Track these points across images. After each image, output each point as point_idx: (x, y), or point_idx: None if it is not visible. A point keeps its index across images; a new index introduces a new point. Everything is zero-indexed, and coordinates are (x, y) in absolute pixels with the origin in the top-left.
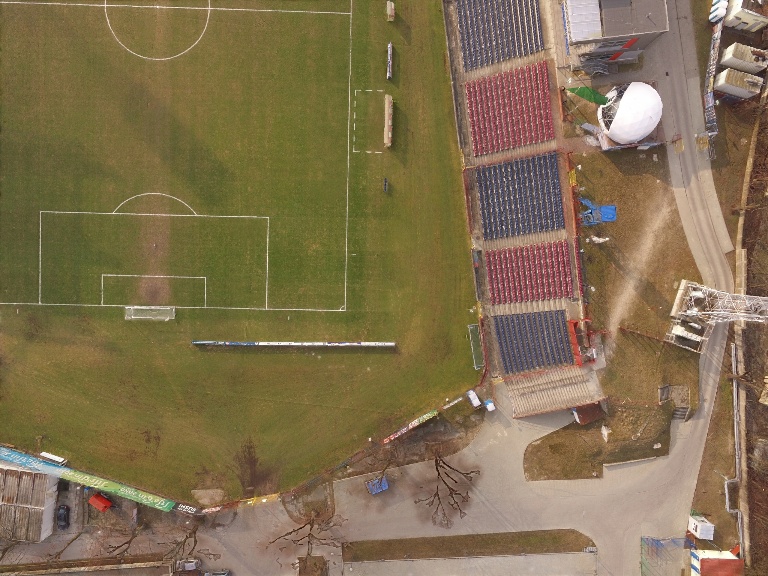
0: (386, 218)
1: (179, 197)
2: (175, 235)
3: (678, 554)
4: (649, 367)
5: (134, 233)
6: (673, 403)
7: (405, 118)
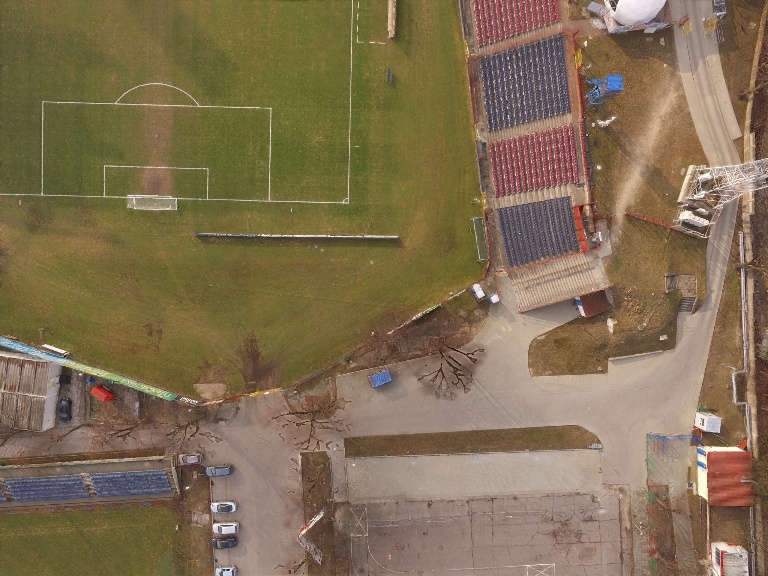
0: (390, 110)
1: (181, 87)
2: (177, 126)
3: (684, 451)
4: (655, 254)
5: (136, 124)
6: (680, 293)
7: (409, 8)
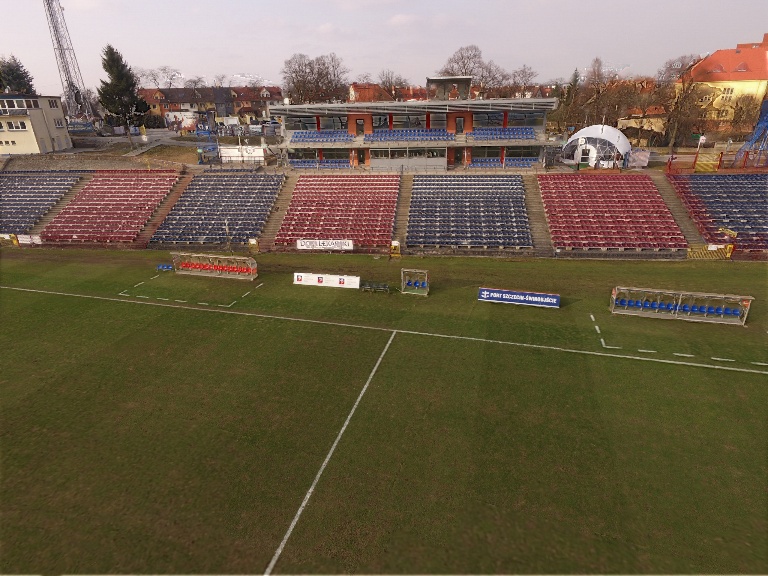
0: None
1: None
2: None
3: None
4: None
5: None
6: None
7: None
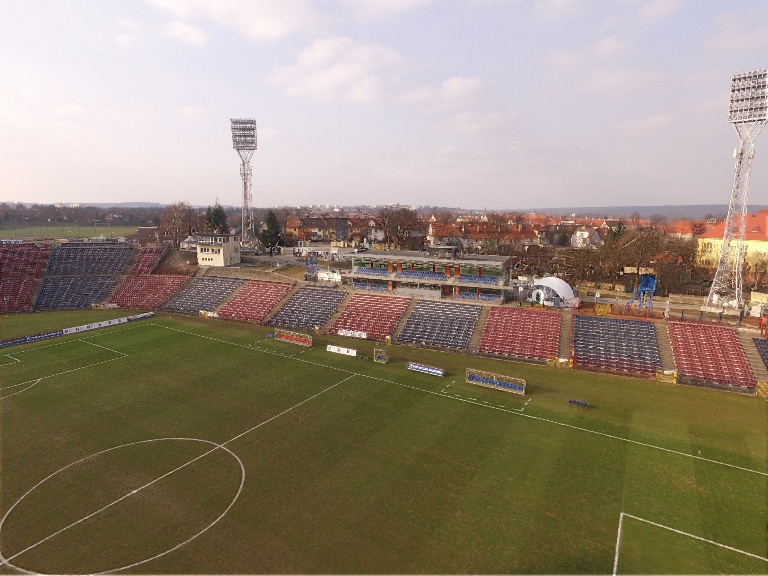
0: (630, 417)
1: None
2: None
3: None
4: None
5: None
6: None
7: None
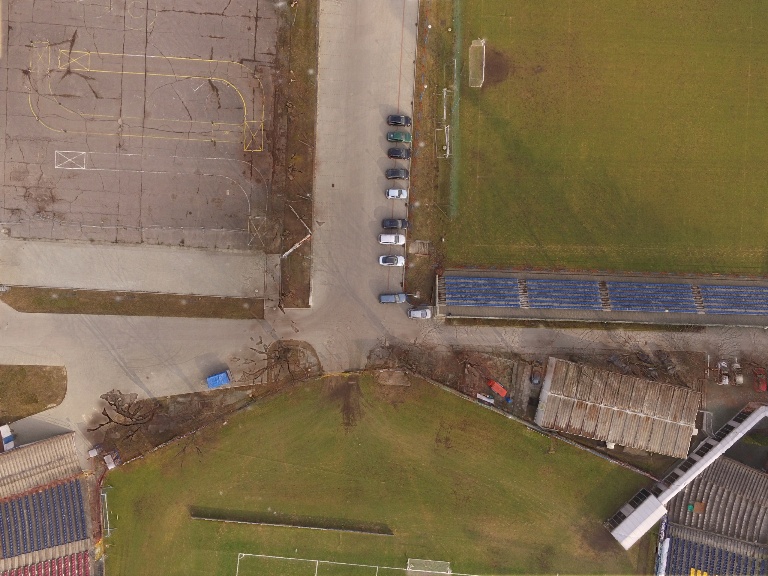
0: None
1: None
2: None
3: None
4: None
5: None
6: None
7: None
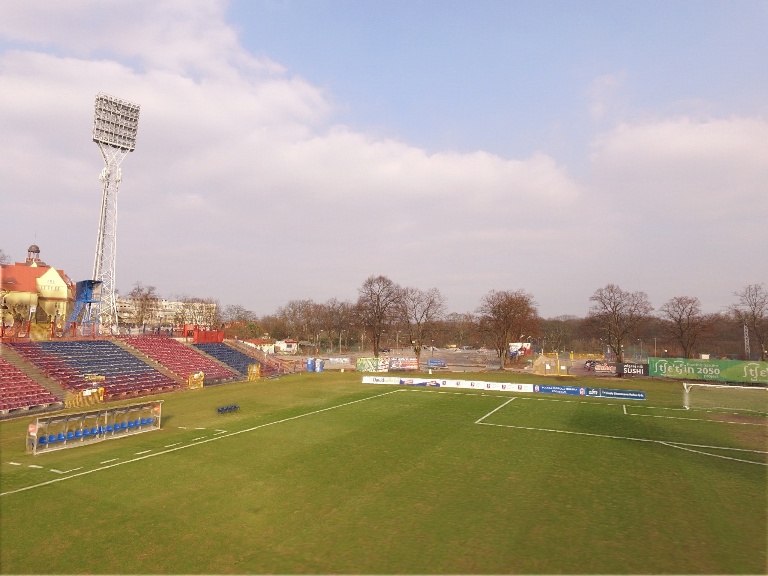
0: None
1: None
2: None
3: None
4: None
5: None
6: None
7: None
